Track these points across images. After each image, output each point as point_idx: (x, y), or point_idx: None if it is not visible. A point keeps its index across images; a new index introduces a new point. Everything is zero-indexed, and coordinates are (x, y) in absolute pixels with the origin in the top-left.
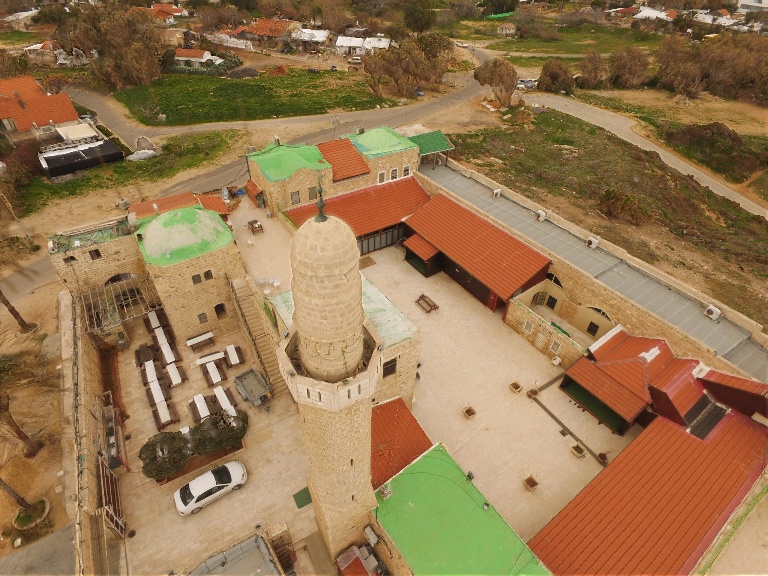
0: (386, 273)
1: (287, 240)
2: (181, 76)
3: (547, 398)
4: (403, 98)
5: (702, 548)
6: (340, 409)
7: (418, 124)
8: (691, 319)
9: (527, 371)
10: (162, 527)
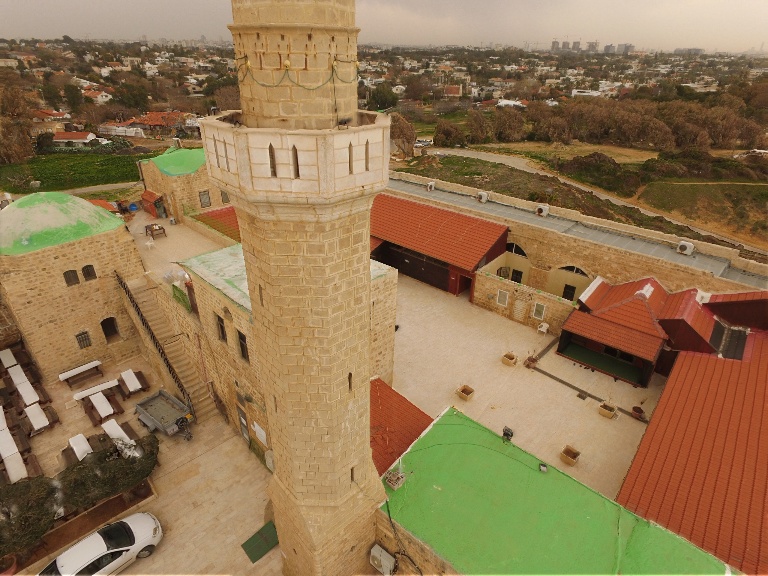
0: None
1: (198, 240)
2: (61, 155)
3: (548, 365)
4: None
5: None
6: (336, 196)
7: None
8: (668, 257)
9: (515, 343)
10: None
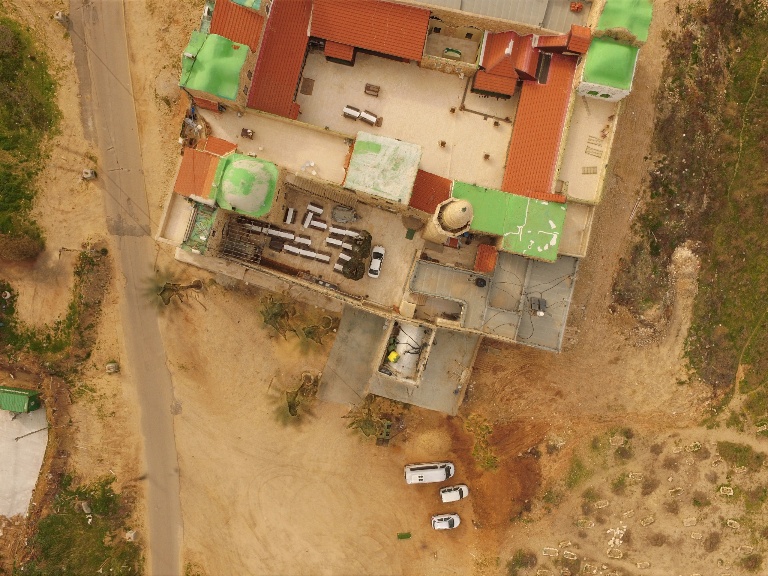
0: (328, 84)
1: (275, 126)
2: None
3: (469, 104)
4: None
5: (559, 143)
6: None
7: None
8: (521, 1)
9: (451, 94)
10: (374, 286)
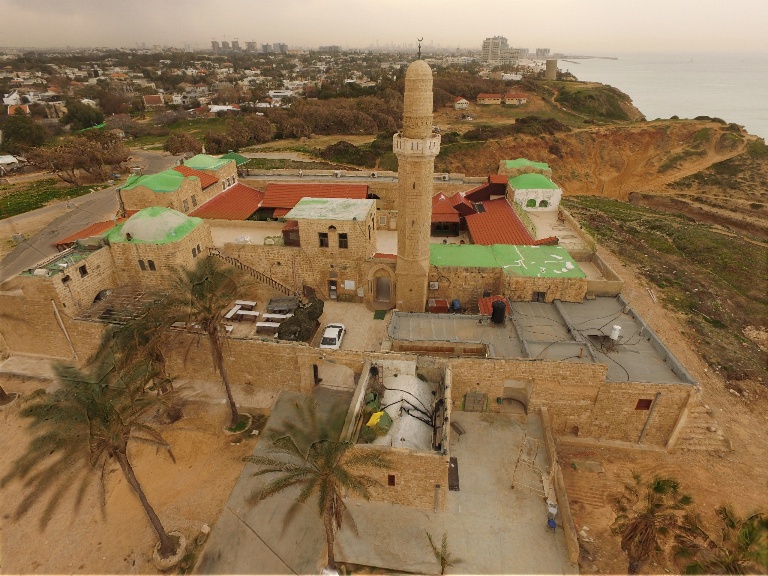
0: None
1: (210, 229)
2: None
3: None
4: (105, 182)
5: None
6: None
7: None
8: None
9: None
10: (331, 367)
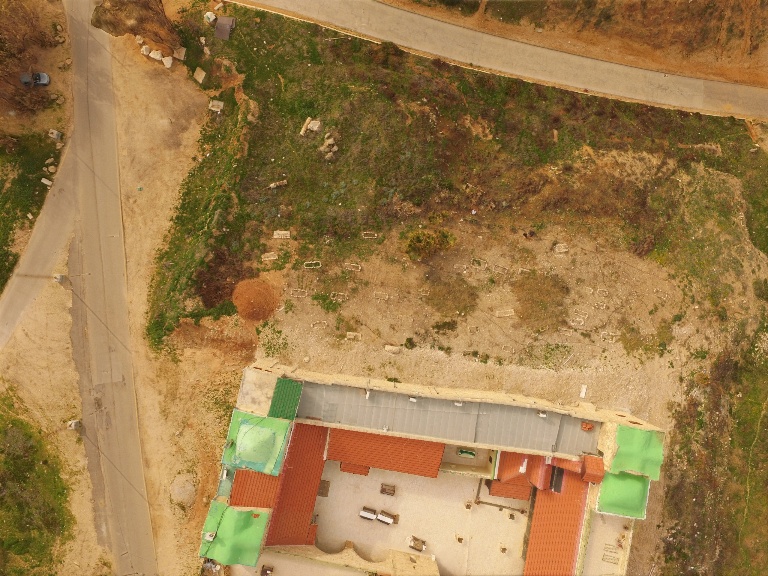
0: (344, 485)
1: (294, 560)
2: None
3: (484, 496)
4: (40, 118)
5: (576, 556)
6: None
7: (246, 371)
8: (533, 426)
9: (466, 488)
10: None
